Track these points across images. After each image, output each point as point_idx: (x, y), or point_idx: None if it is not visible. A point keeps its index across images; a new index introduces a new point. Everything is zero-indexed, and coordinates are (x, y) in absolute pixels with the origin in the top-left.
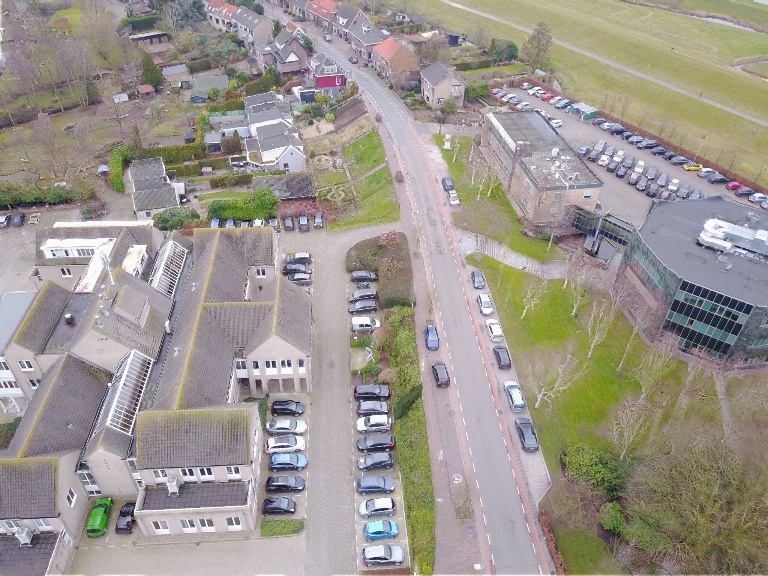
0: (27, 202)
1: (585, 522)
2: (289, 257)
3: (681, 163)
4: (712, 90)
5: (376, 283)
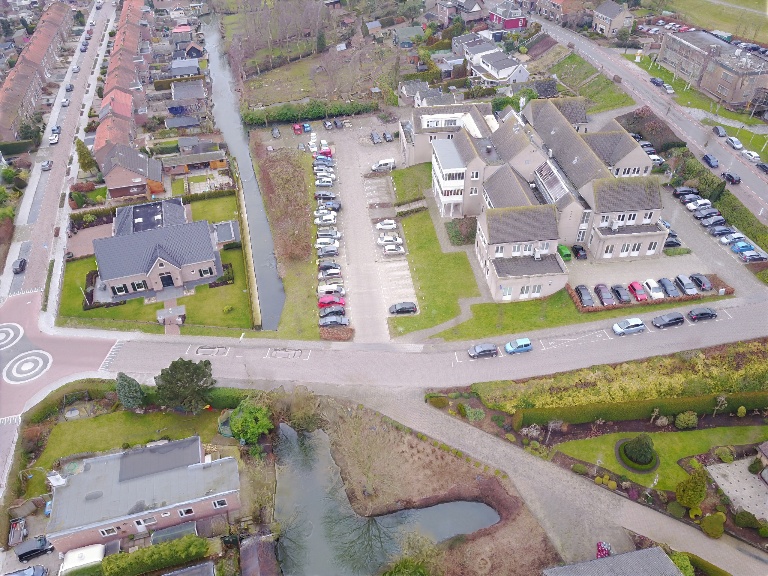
0: (331, 115)
1: None
2: None
3: None
4: None
5: None
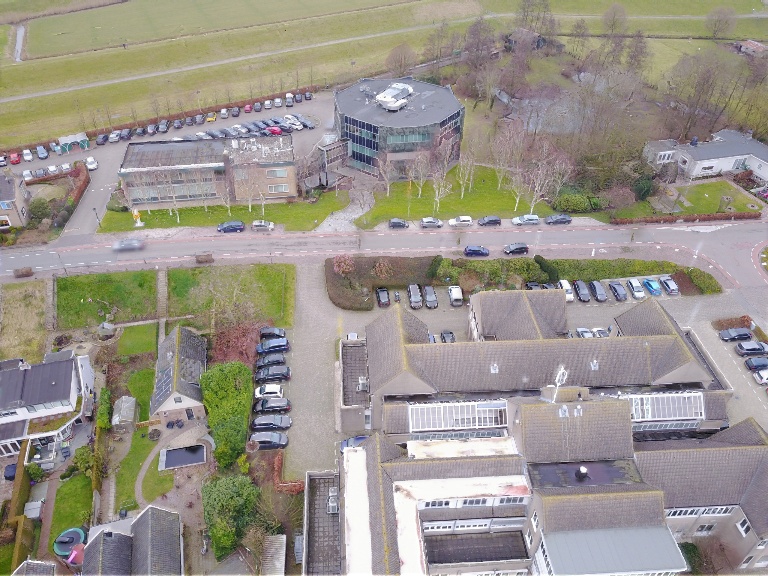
0: None
1: None
2: None
3: (204, 120)
4: (86, 75)
5: (390, 291)
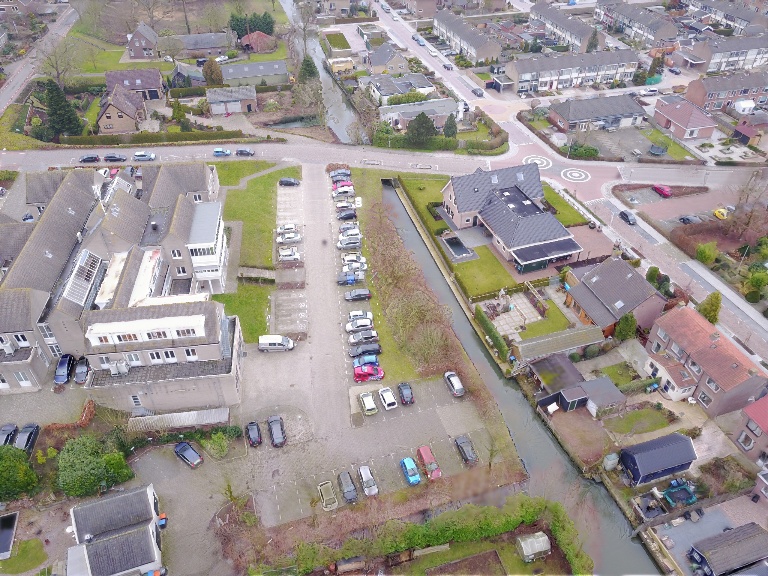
0: None
1: None
2: None
3: None
4: None
5: None
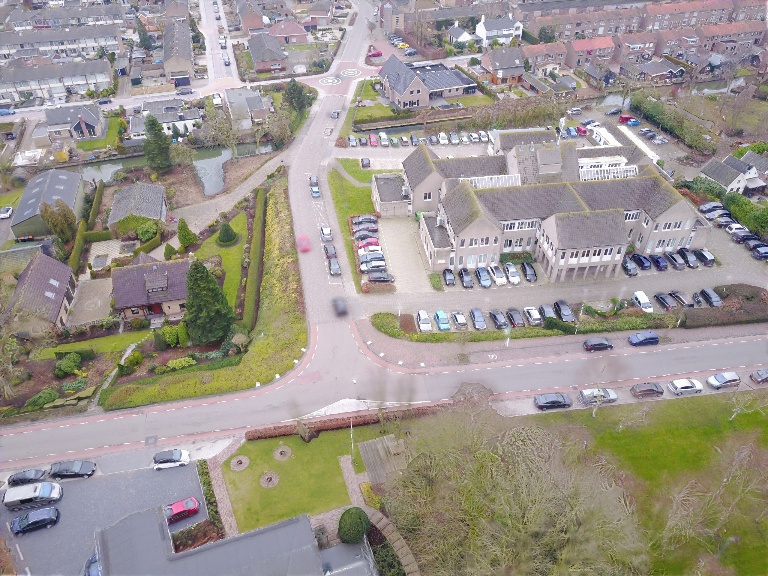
0: None
1: (455, 401)
2: (700, 249)
3: None
4: None
5: None
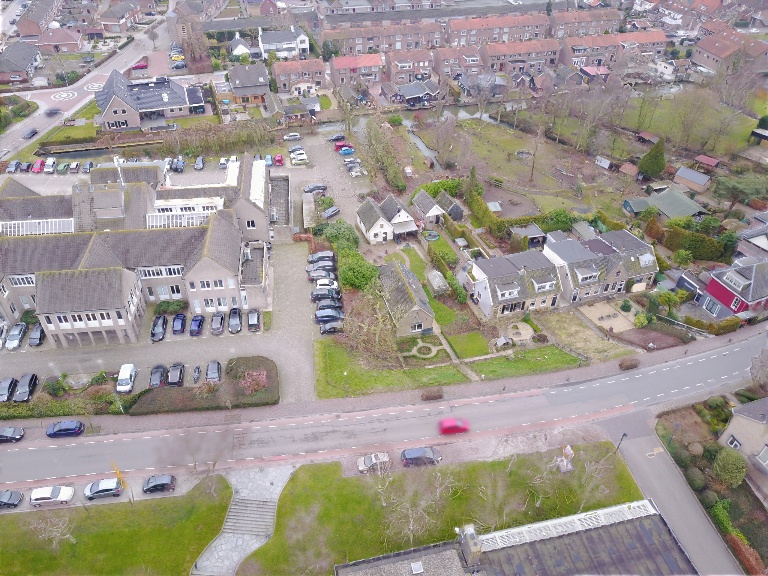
0: None
1: None
2: (254, 310)
3: None
4: None
5: None
